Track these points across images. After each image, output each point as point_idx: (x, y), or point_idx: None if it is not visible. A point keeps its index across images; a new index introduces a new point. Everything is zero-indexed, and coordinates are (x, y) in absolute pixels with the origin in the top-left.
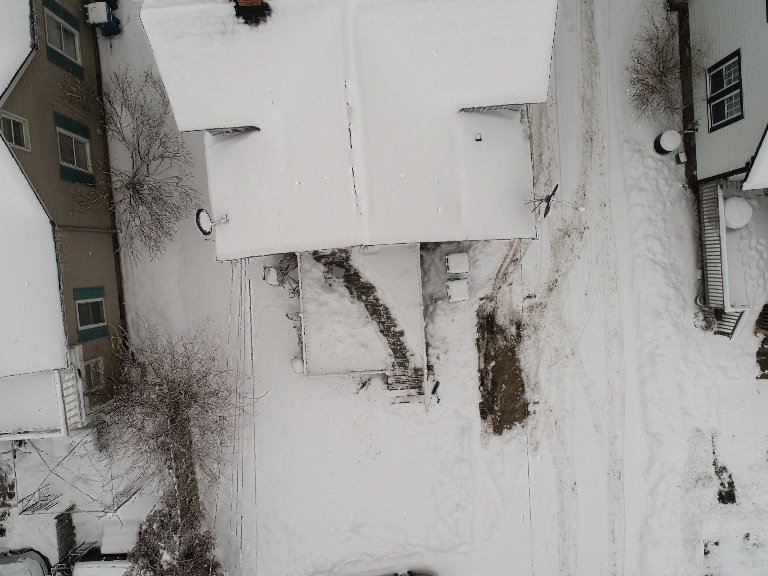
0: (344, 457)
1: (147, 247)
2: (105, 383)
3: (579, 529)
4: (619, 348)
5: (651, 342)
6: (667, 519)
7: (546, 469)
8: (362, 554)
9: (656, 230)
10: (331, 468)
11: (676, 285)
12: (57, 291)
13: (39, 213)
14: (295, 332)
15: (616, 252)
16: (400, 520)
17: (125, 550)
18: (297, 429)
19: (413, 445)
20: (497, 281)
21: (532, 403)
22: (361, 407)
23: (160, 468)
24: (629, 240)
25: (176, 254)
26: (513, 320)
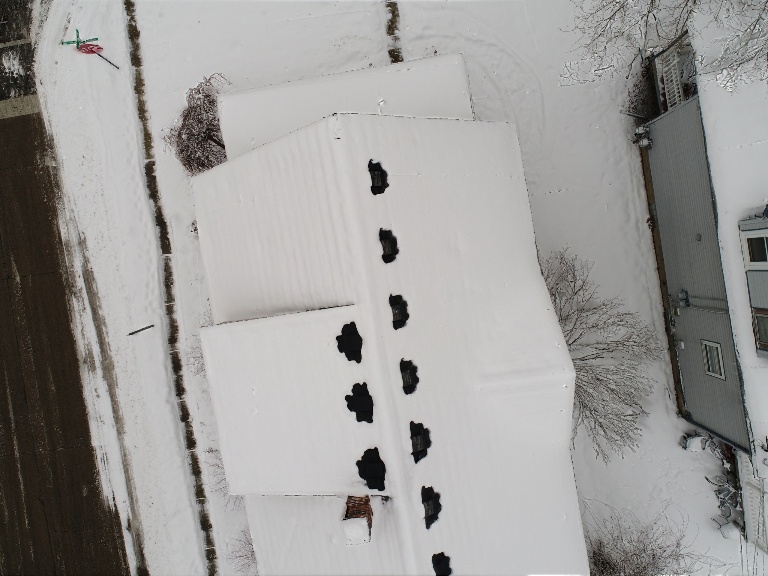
0: None
1: (607, 440)
2: None
3: None
4: None
5: None
6: None
7: None
8: None
9: None
10: None
11: None
12: (579, 515)
13: (568, 442)
14: (713, 495)
15: None
16: None
17: None
18: None
19: None
20: None
21: None
22: None
23: None
24: None
25: None
26: None
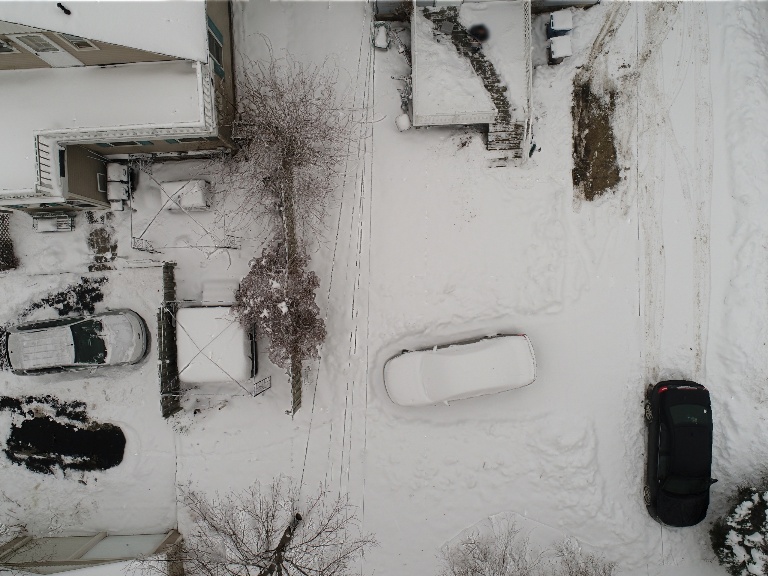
0: (440, 220)
1: None
2: (223, 121)
3: (666, 291)
4: (708, 117)
5: (740, 108)
6: (752, 278)
7: (635, 233)
8: (453, 316)
9: (747, 2)
10: (427, 231)
11: (765, 54)
12: None
13: None
14: (398, 96)
15: (708, 25)
16: (492, 282)
17: (231, 290)
18: (395, 192)
19: (507, 208)
20: (593, 51)
21: (623, 169)
22: (459, 169)
23: (270, 208)
24: (721, 12)
25: (286, 22)
26: (607, 89)
